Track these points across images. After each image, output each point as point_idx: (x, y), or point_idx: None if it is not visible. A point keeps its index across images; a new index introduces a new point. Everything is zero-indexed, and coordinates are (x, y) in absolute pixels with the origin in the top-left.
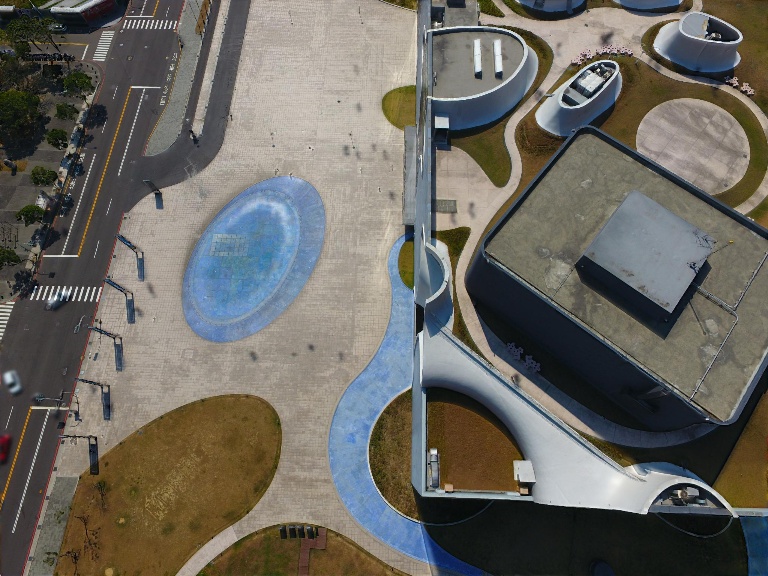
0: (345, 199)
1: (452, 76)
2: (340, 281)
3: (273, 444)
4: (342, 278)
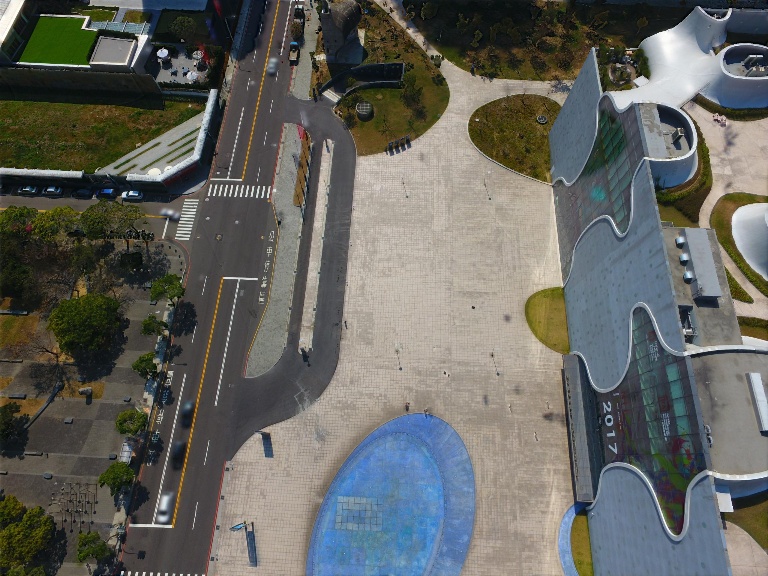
0: (495, 450)
1: (729, 430)
2: (502, 574)
3: None
4: (504, 569)
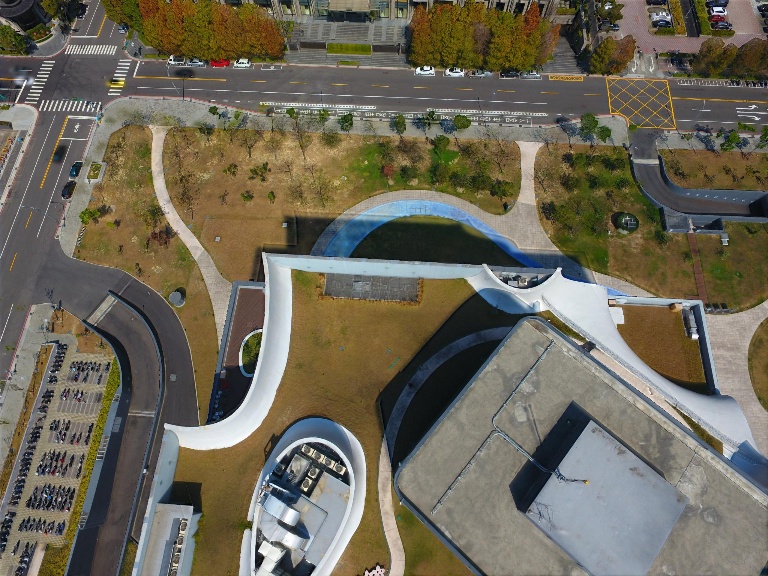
0: None
1: None
2: None
3: (759, 380)
4: None
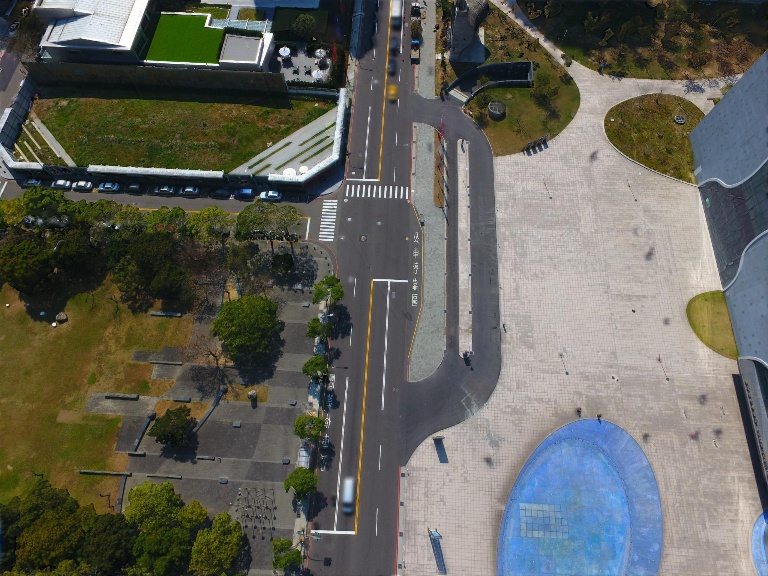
0: (675, 456)
1: None
2: None
3: None
4: None
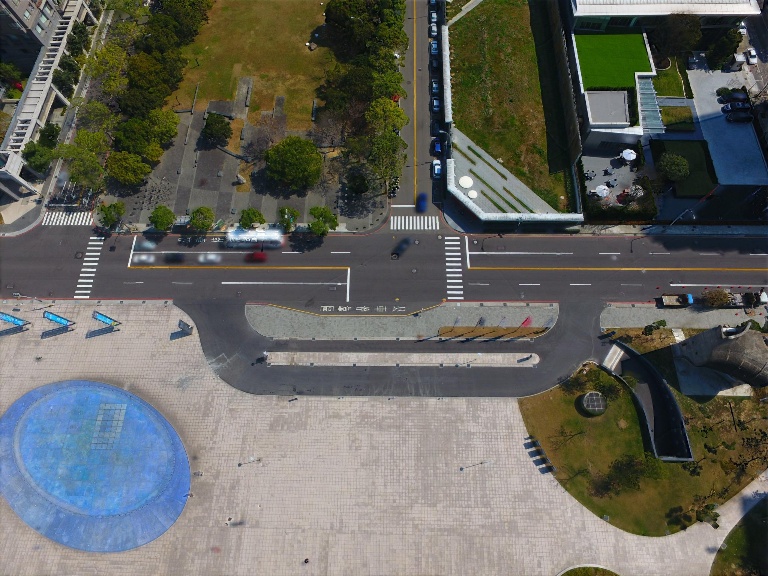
0: None
1: None
2: None
3: None
4: None
